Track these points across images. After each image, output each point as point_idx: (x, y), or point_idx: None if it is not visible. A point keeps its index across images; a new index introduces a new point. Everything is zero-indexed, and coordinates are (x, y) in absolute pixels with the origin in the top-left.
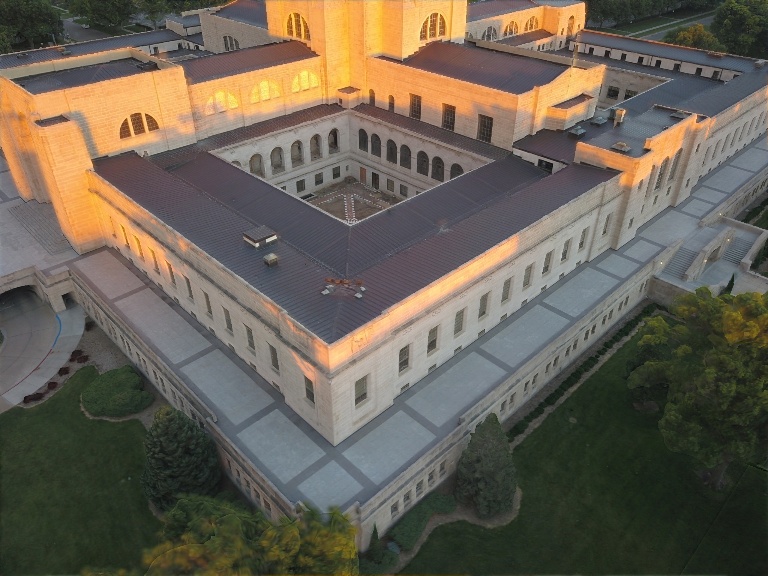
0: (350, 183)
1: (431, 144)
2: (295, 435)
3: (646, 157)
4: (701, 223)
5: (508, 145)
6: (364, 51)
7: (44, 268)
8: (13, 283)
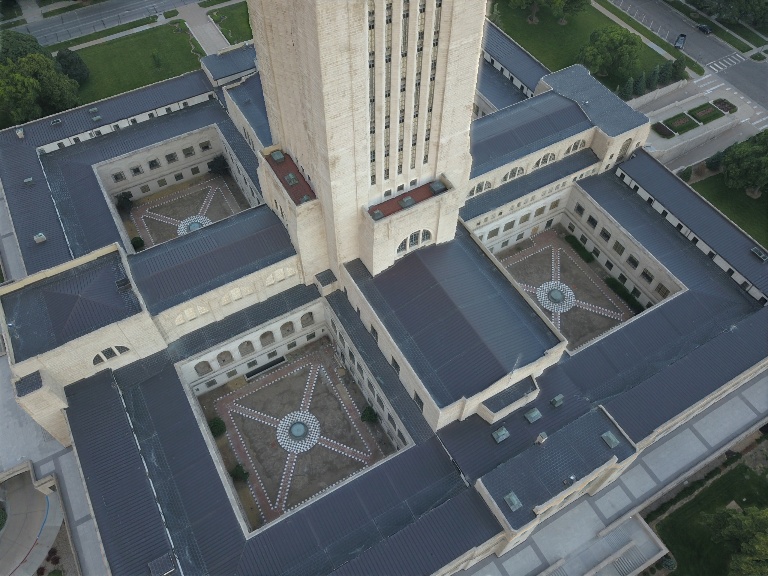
0: (323, 345)
1: (374, 387)
2: None
3: (527, 527)
4: (598, 535)
5: (433, 429)
6: (338, 260)
7: (37, 460)
8: (13, 473)
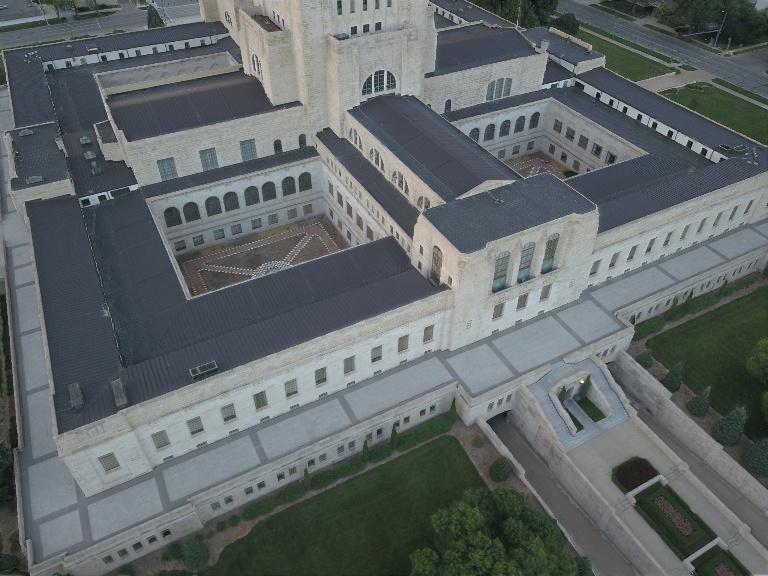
0: None
1: None
2: None
3: None
4: None
5: None
6: None
7: None
8: None
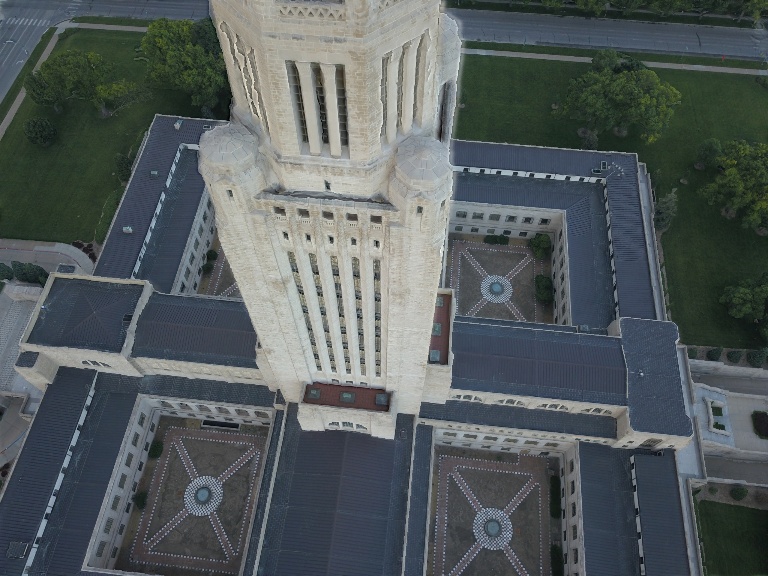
0: None
1: None
2: None
3: None
4: None
5: None
6: None
7: (33, 397)
8: None
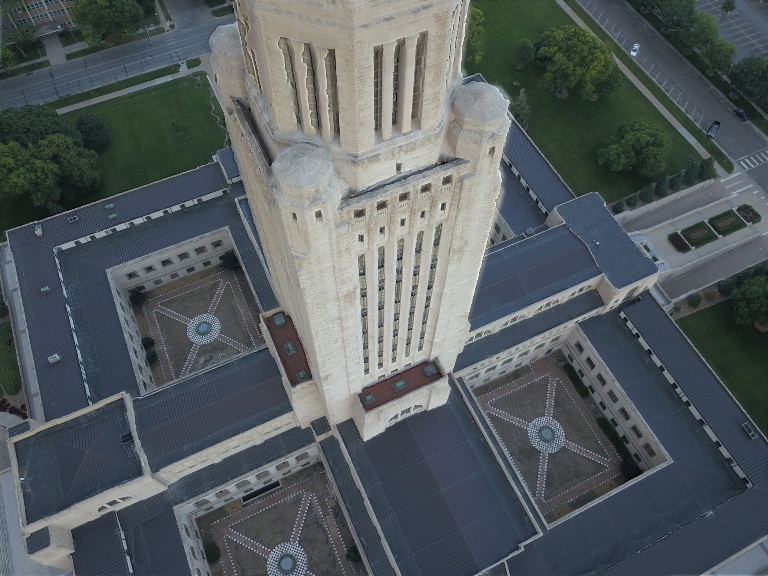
0: (317, 471)
1: None
2: None
3: None
4: None
5: None
6: (331, 423)
7: None
8: None
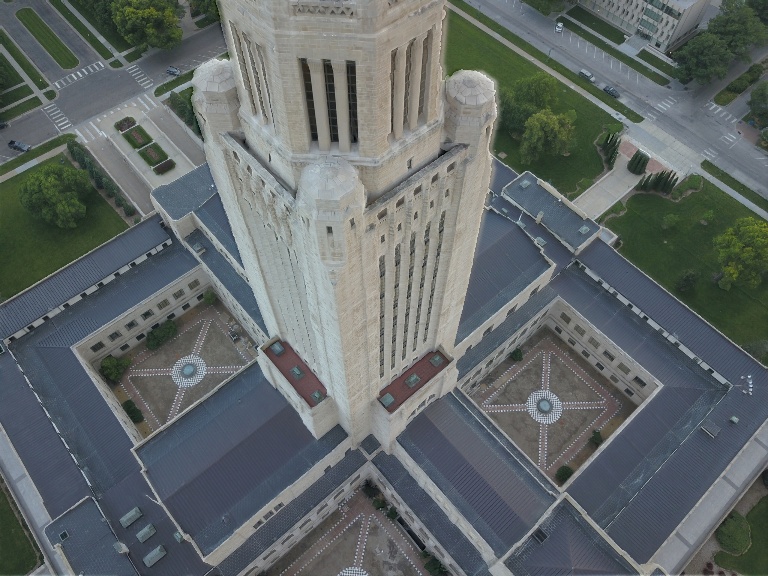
0: None
1: None
2: (766, 425)
3: None
4: None
5: None
6: None
7: None
8: None
